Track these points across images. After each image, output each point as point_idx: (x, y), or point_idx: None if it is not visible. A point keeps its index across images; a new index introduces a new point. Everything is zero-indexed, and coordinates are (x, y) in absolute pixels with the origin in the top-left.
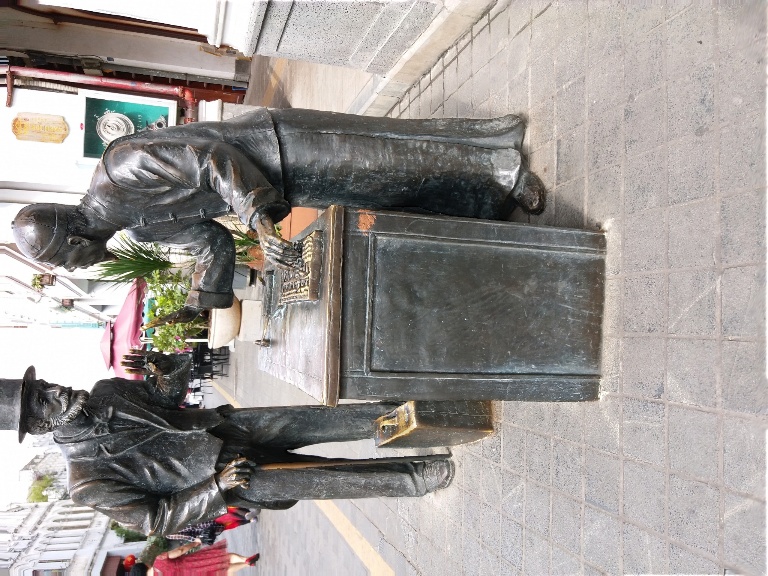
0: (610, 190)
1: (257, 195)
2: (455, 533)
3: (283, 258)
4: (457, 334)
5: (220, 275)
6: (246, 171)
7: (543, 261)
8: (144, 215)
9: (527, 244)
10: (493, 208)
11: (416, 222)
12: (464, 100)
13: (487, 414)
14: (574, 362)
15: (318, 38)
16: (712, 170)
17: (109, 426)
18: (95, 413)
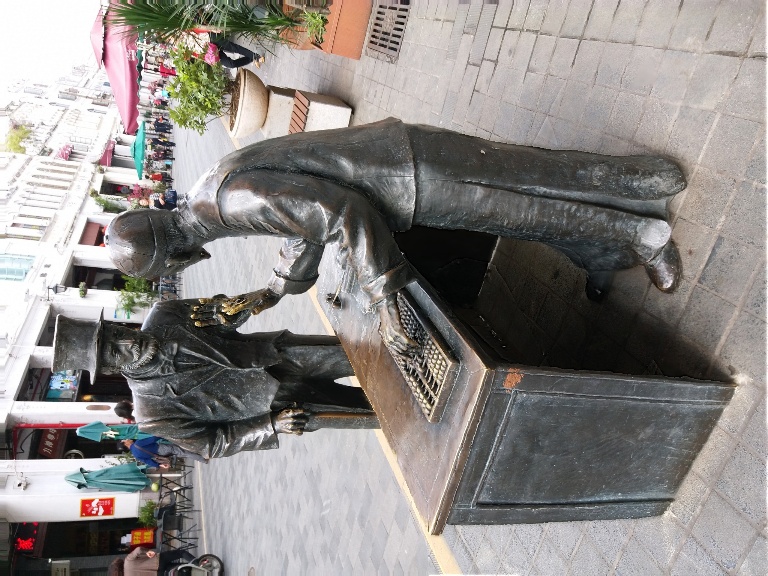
0: (762, 349)
1: (389, 280)
2: None
3: (405, 353)
4: (564, 475)
5: (309, 264)
6: (379, 242)
7: (667, 412)
8: None
9: (659, 399)
10: (616, 263)
11: (561, 381)
12: (612, 65)
13: None
14: (656, 489)
15: None
16: None
17: (174, 364)
18: (160, 348)
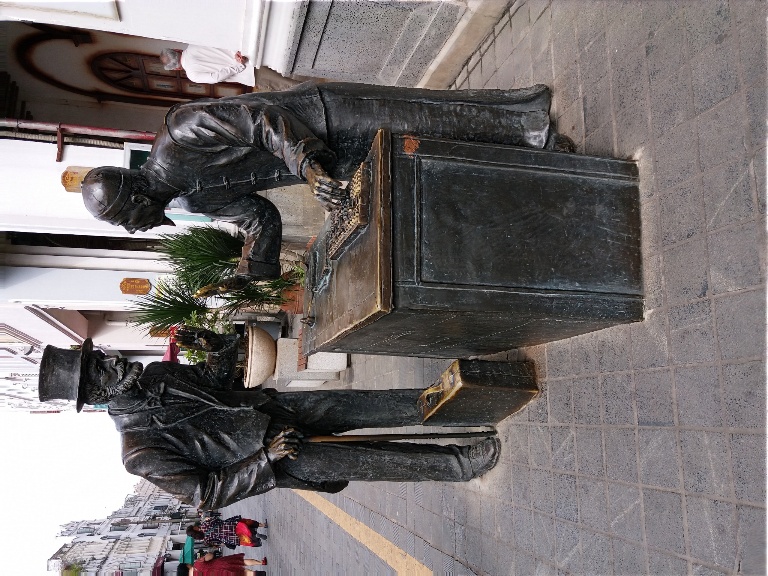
0: (638, 123)
1: (307, 143)
2: (505, 511)
3: (332, 197)
4: (502, 250)
5: (268, 246)
6: (296, 126)
7: (579, 186)
8: (200, 178)
9: (563, 169)
10: None
11: (457, 147)
12: None
13: (531, 375)
14: (616, 282)
15: (351, 51)
16: (734, 69)
17: (161, 400)
18: (147, 389)
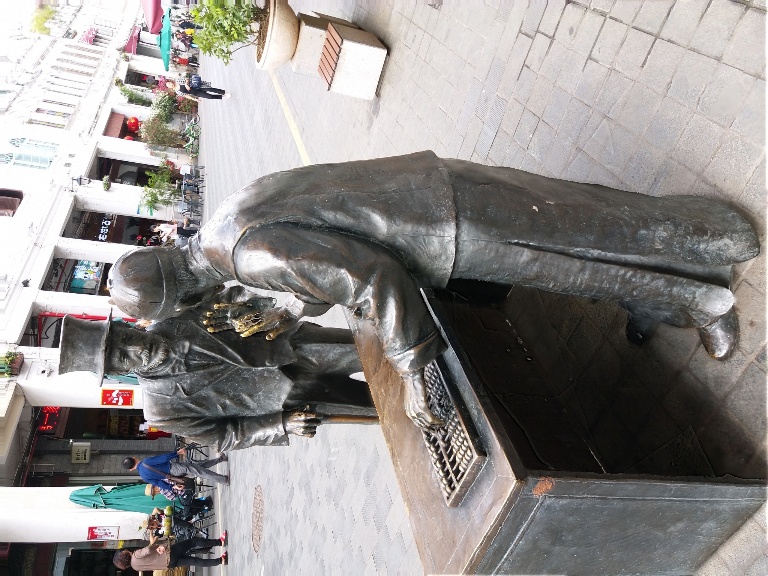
0: None
1: (417, 355)
2: None
3: None
4: (583, 562)
5: None
6: (410, 312)
7: (703, 508)
8: None
9: (697, 499)
10: (666, 319)
11: (595, 486)
12: (690, 80)
13: None
14: (677, 569)
15: None
16: None
17: (185, 363)
18: (171, 345)
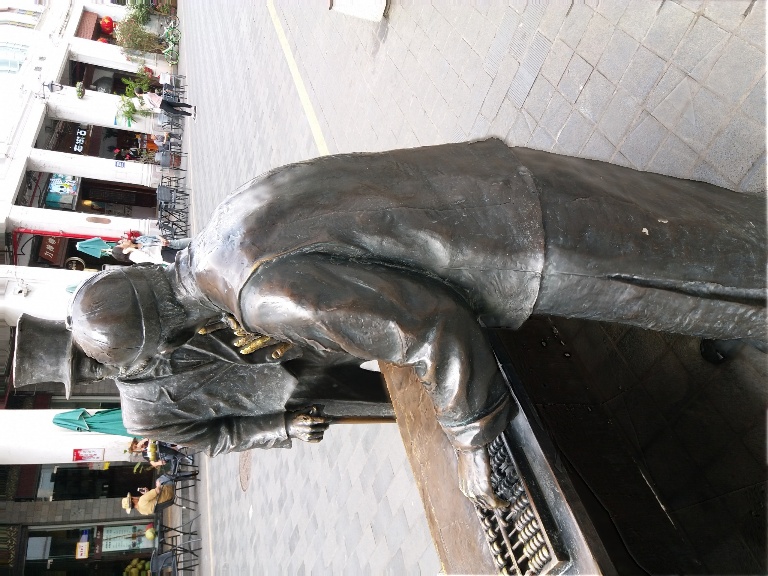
0: None
1: (484, 428)
2: None
3: None
4: None
5: None
6: (477, 373)
7: None
8: None
9: None
10: (767, 349)
11: None
12: None
13: None
14: None
15: None
16: None
17: (171, 363)
18: None
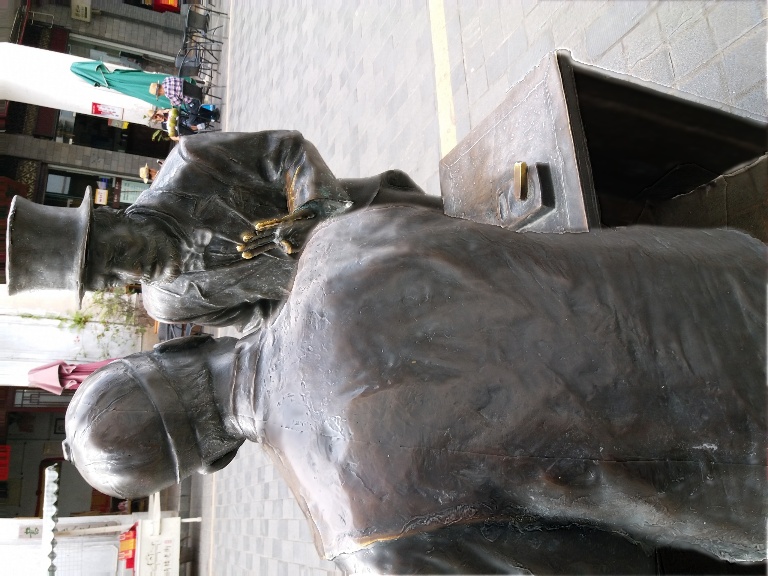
0: None
1: None
2: None
3: None
4: None
5: None
6: None
7: None
8: None
9: None
10: None
11: None
12: None
13: None
14: None
15: None
16: None
17: (204, 257)
18: (184, 233)
